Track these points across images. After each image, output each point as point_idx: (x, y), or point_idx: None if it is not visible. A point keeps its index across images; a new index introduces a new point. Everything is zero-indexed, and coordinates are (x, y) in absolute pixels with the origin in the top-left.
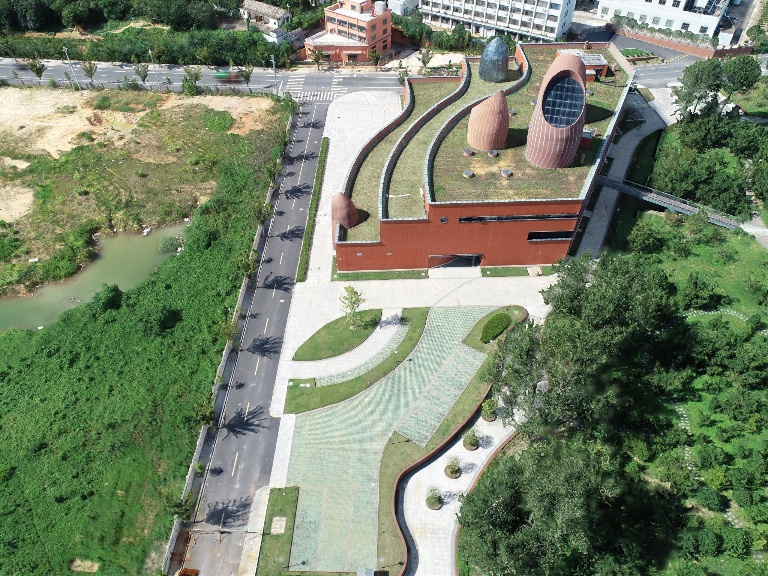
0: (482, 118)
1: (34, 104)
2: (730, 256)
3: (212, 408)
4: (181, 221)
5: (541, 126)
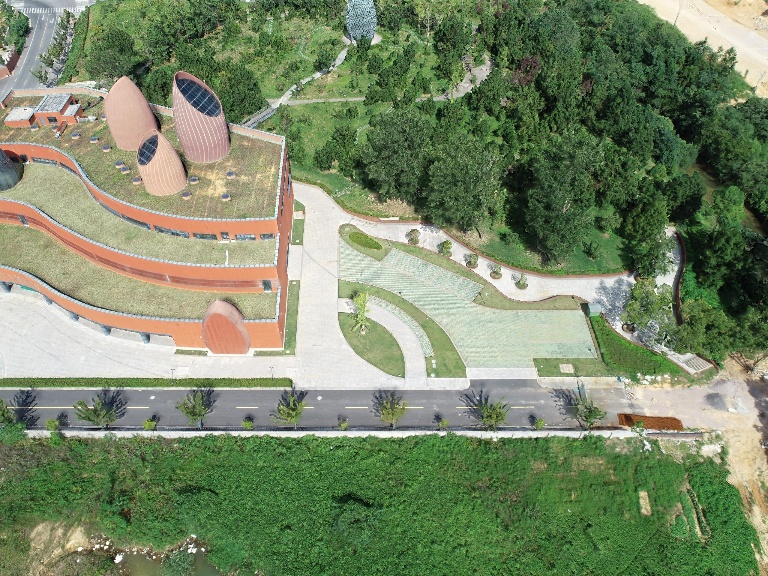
0: (169, 160)
1: None
2: None
3: (494, 406)
4: (120, 567)
5: (209, 124)
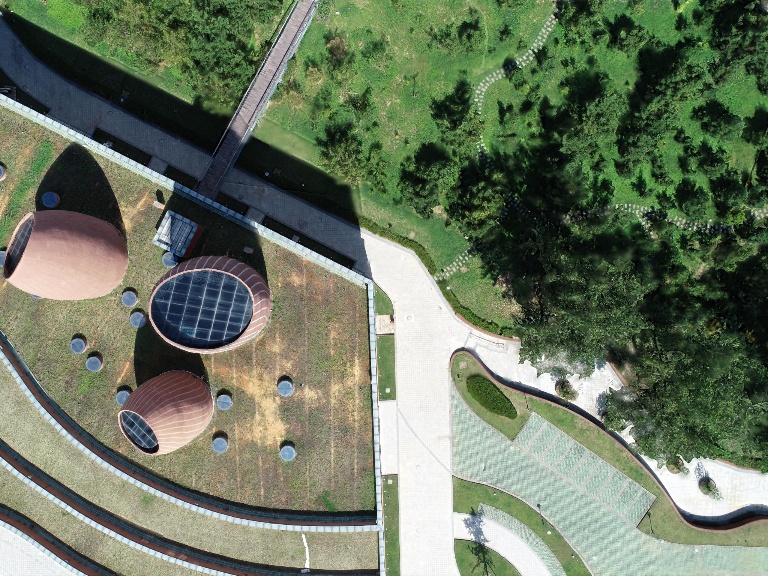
0: (183, 440)
1: None
2: (376, 44)
3: None
4: None
5: None
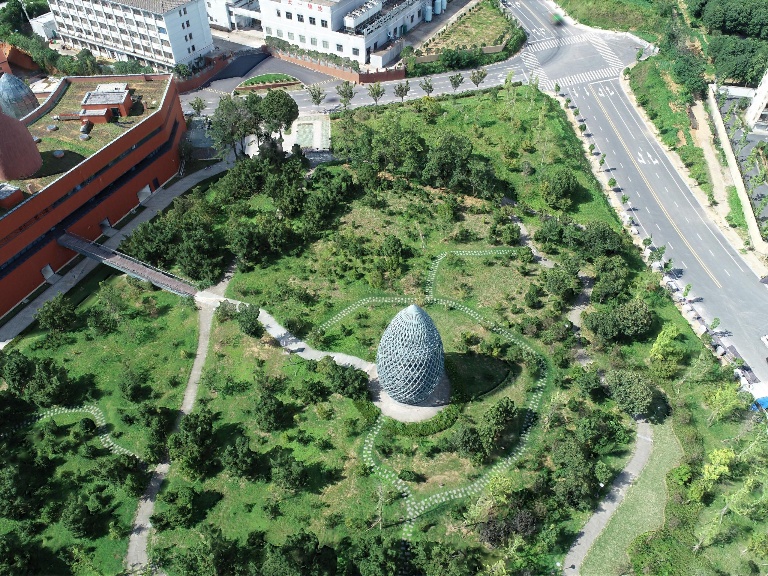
0: None
1: None
2: (152, 334)
3: None
4: None
5: None
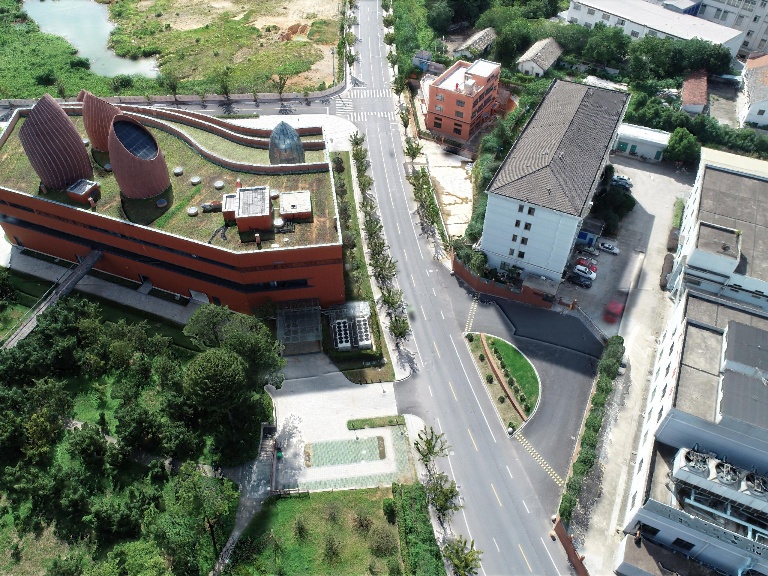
0: None
1: (319, 5)
2: None
3: None
4: None
5: None
